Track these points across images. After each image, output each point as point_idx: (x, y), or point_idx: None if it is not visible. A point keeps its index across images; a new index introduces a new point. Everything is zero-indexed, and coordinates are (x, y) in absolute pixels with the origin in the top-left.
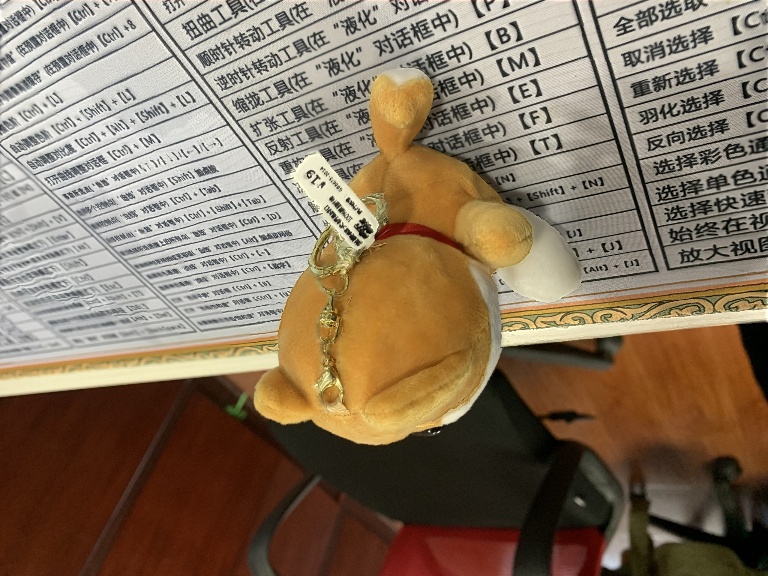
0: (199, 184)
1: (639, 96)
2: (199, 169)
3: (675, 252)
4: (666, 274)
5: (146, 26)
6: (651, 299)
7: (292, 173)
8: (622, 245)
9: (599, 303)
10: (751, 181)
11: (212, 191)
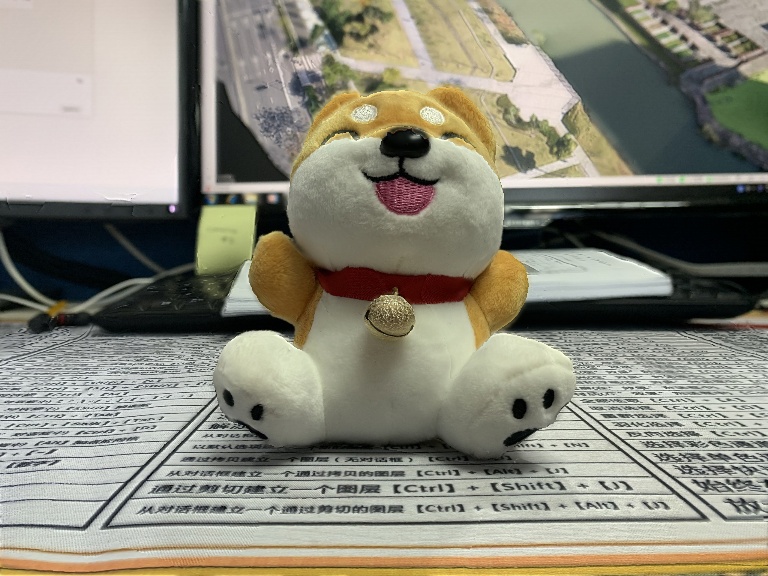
0: None
1: (609, 418)
2: None
3: (718, 500)
4: (725, 526)
5: None
6: (728, 568)
7: None
8: (631, 486)
9: (618, 566)
10: (759, 461)
11: None
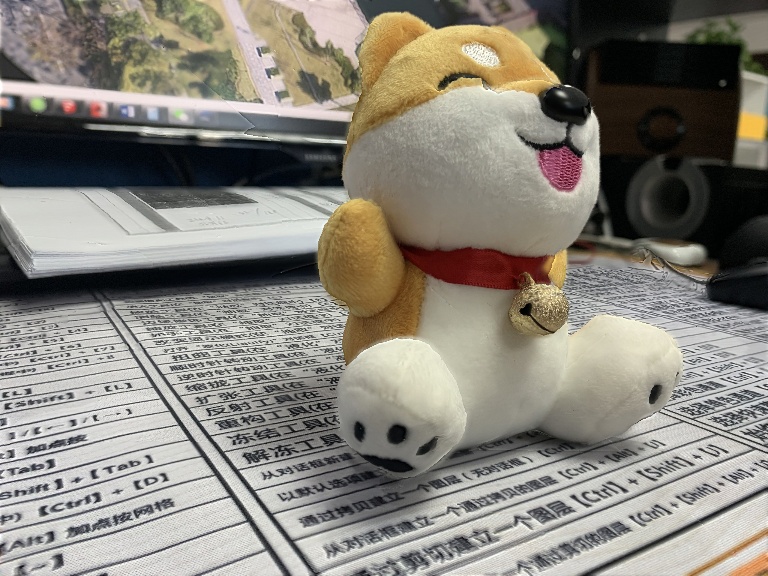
0: (10, 465)
1: None
2: (43, 445)
3: None
4: None
5: (129, 356)
6: None
7: (233, 428)
8: None
9: None
10: None
11: (30, 471)
